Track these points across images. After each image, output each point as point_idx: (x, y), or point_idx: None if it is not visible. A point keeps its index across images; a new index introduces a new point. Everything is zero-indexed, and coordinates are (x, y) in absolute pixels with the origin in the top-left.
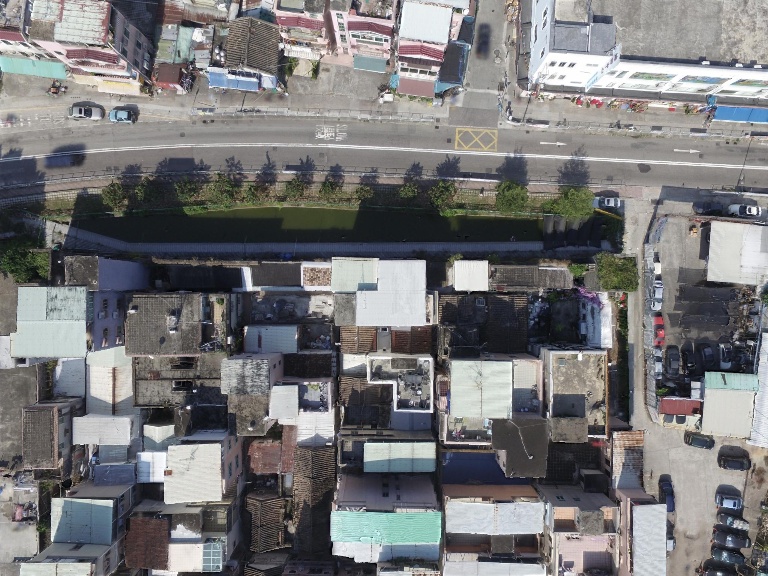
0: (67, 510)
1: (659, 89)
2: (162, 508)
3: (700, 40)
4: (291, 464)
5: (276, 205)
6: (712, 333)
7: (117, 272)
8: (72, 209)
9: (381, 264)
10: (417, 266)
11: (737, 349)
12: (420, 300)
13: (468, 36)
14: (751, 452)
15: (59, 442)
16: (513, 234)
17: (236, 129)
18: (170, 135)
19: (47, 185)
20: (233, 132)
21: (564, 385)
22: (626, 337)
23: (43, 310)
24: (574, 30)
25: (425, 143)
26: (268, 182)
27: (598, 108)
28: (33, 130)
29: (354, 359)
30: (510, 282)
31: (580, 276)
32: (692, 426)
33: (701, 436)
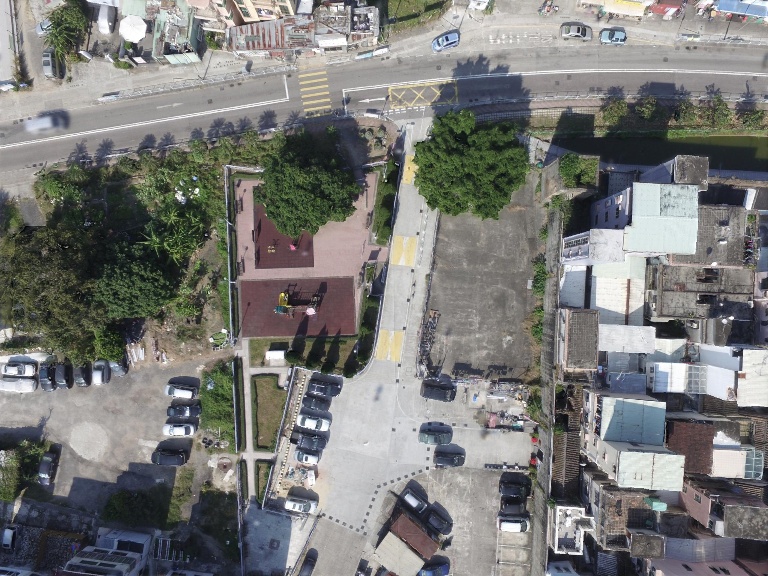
0: (619, 409)
1: None
2: None
3: None
4: None
5: (753, 134)
6: None
7: None
8: (554, 127)
9: None
10: None
11: None
12: None
13: None
14: None
15: None
16: None
17: (718, 57)
18: (653, 59)
19: (532, 102)
20: (715, 60)
21: None
22: None
23: (657, 206)
24: None
25: None
26: (748, 111)
27: None
28: (521, 47)
29: None
30: None
31: None
32: None
33: None
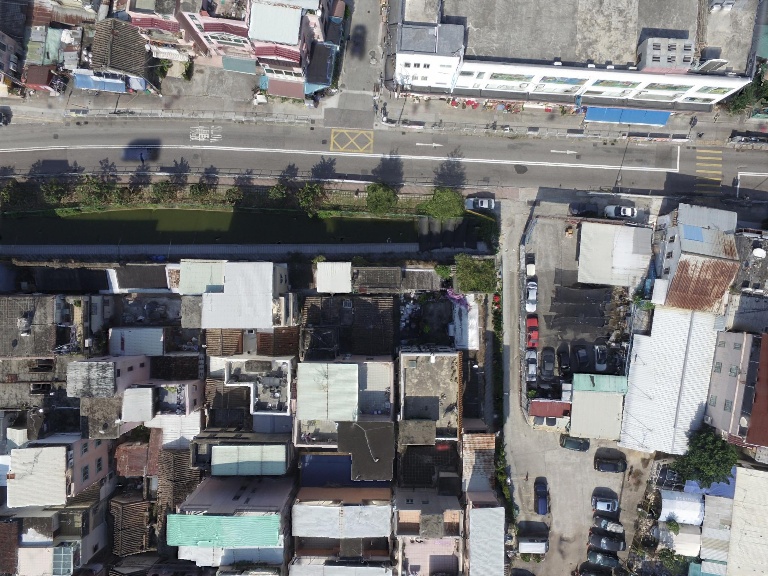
0: None
1: (526, 90)
2: (18, 511)
3: (555, 41)
4: (157, 467)
5: (150, 207)
6: (588, 335)
7: None
8: None
9: (228, 266)
10: (264, 268)
11: (613, 351)
12: (266, 302)
13: (336, 37)
14: (628, 454)
15: None
16: (389, 236)
17: (110, 131)
18: (43, 137)
19: None
20: (107, 134)
21: (418, 387)
22: (500, 339)
23: None
24: (422, 31)
25: (300, 144)
26: (142, 184)
27: (474, 109)
28: None
29: (221, 361)
30: (372, 284)
31: (451, 278)
32: (563, 428)
33: (575, 438)
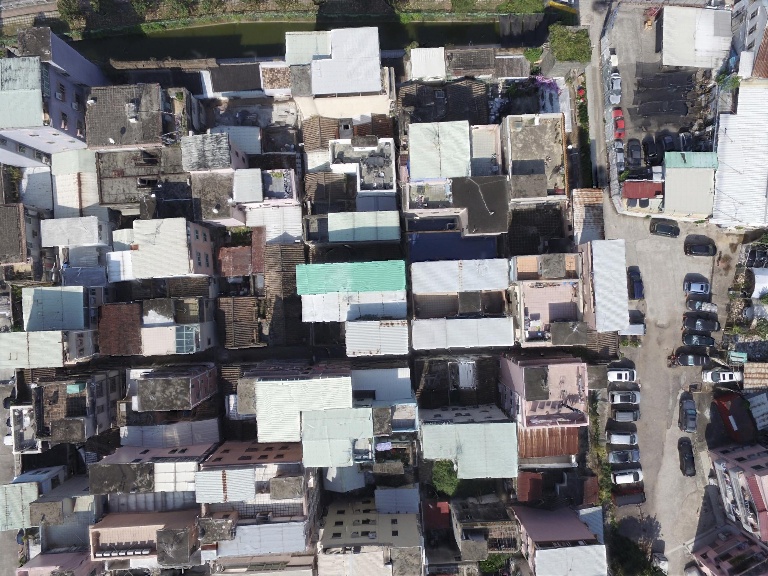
0: (38, 299)
1: None
2: None
3: None
4: (262, 265)
5: (234, 21)
6: (672, 125)
7: (73, 59)
8: None
9: (334, 33)
10: (370, 33)
11: (697, 138)
12: (374, 66)
13: None
14: (716, 240)
15: (27, 240)
16: (471, 39)
17: None
18: None
19: (4, 11)
20: None
21: (523, 152)
22: (587, 130)
23: None
24: None
25: None
26: None
27: None
28: None
29: (318, 158)
30: (466, 66)
31: (538, 68)
32: (655, 209)
33: (666, 224)
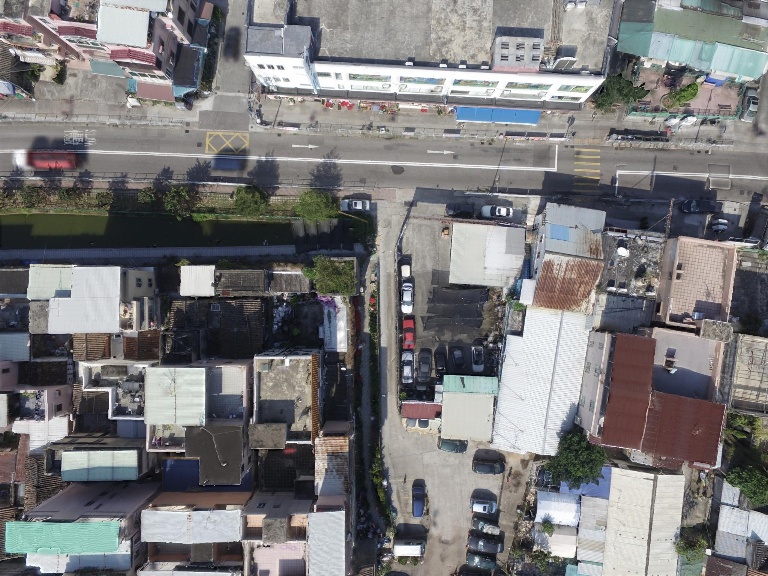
0: None
1: (392, 90)
2: None
3: (409, 41)
4: (25, 473)
5: (24, 212)
6: (466, 336)
7: None
8: None
9: (75, 271)
10: (111, 272)
11: (490, 351)
12: (114, 307)
13: (202, 39)
14: (507, 455)
15: None
16: (266, 238)
17: None
18: None
19: None
20: None
21: (273, 391)
22: (375, 341)
23: None
24: (268, 32)
25: (175, 147)
26: (15, 189)
27: (349, 110)
28: None
29: None
30: (235, 287)
31: None
32: (435, 430)
33: (452, 440)
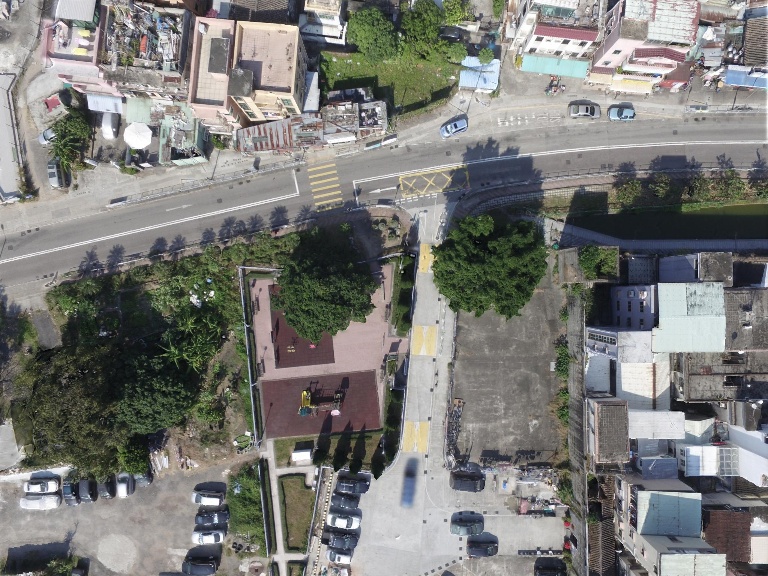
0: (654, 503)
1: None
2: (722, 501)
3: None
4: None
5: (767, 202)
6: None
7: None
8: (568, 206)
9: None
10: None
11: None
12: None
13: None
14: None
15: None
16: None
17: (727, 126)
18: (663, 133)
19: (544, 183)
20: (724, 129)
21: None
22: None
23: (683, 306)
24: None
25: None
26: (760, 179)
27: None
28: (530, 128)
29: None
30: None
31: None
32: None
33: None
